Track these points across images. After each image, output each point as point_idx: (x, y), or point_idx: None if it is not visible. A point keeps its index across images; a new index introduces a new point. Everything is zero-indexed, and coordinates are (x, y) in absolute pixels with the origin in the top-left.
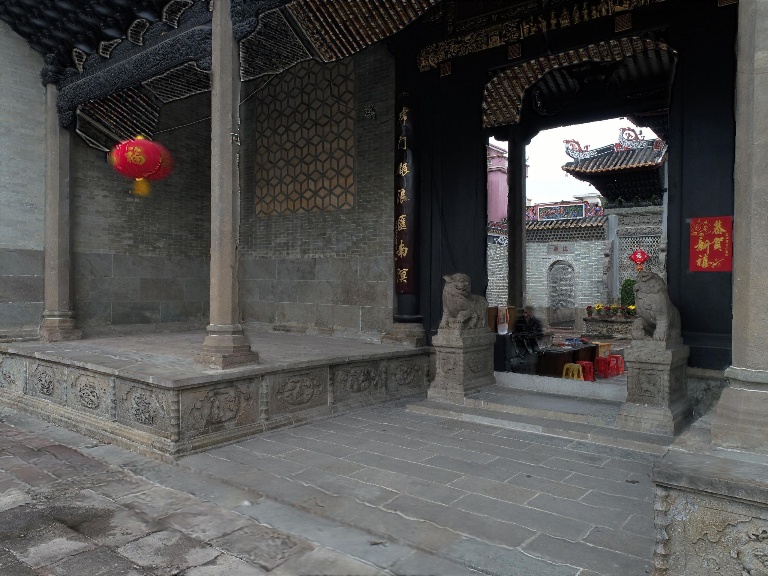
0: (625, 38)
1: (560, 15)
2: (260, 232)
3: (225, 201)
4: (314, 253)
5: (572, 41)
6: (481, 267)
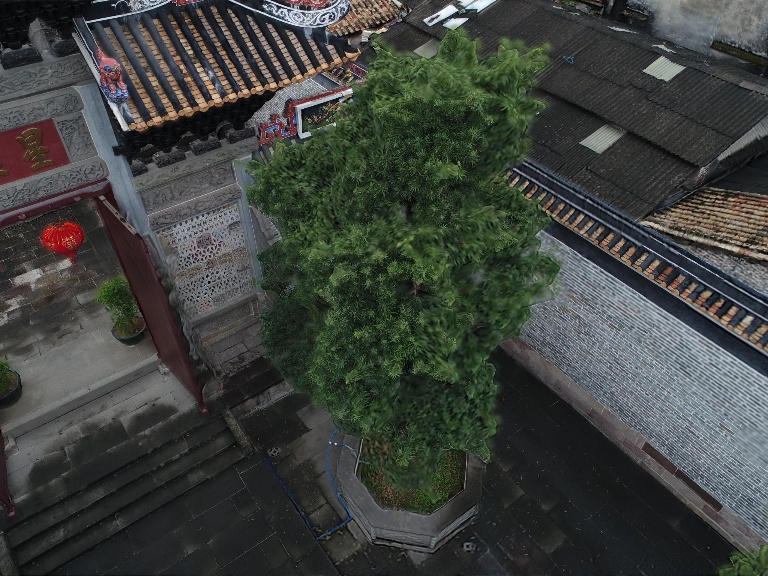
0: None
1: None
2: None
3: None
4: None
5: None
6: None
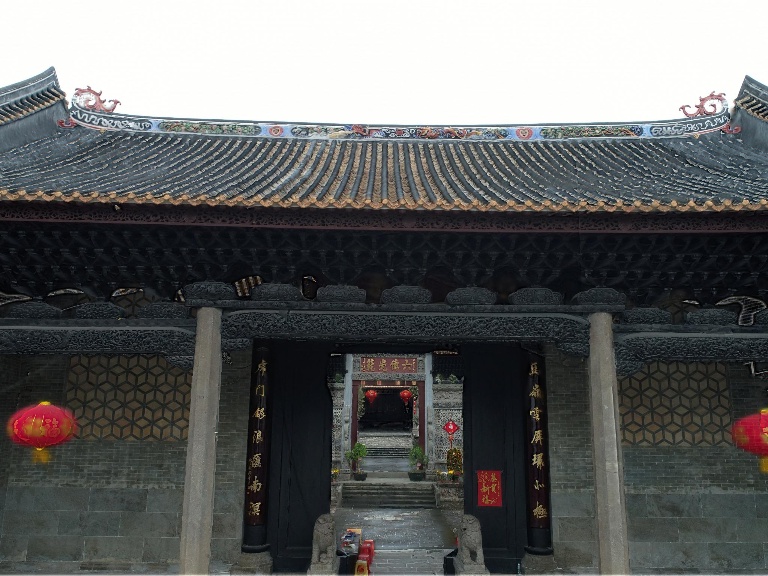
0: None
1: None
2: (67, 457)
3: (207, 495)
4: (146, 483)
5: None
6: (327, 500)
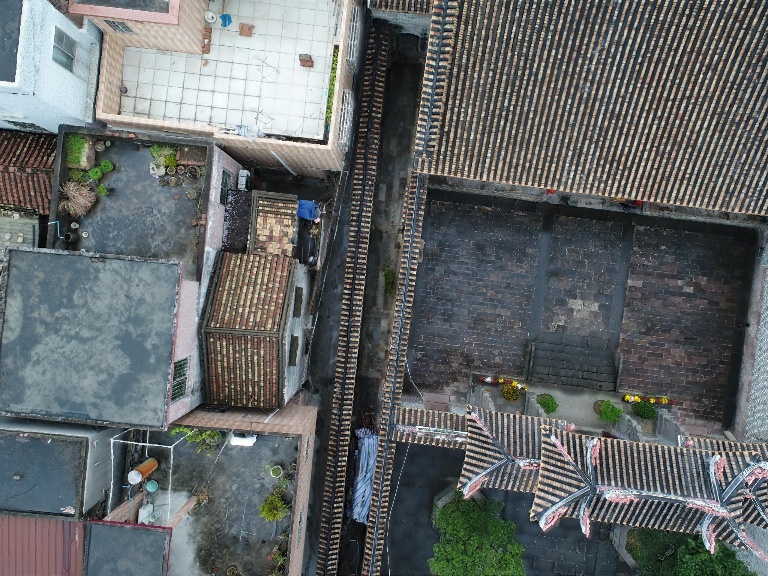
0: (682, 148)
1: None
2: None
3: None
4: None
5: None
6: None
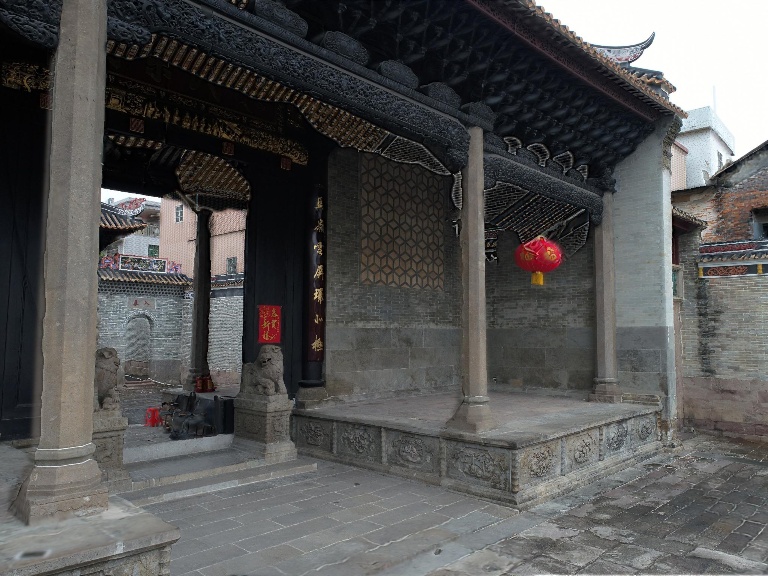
0: None
1: (183, 116)
2: None
3: (94, 259)
4: None
5: (188, 142)
6: None
